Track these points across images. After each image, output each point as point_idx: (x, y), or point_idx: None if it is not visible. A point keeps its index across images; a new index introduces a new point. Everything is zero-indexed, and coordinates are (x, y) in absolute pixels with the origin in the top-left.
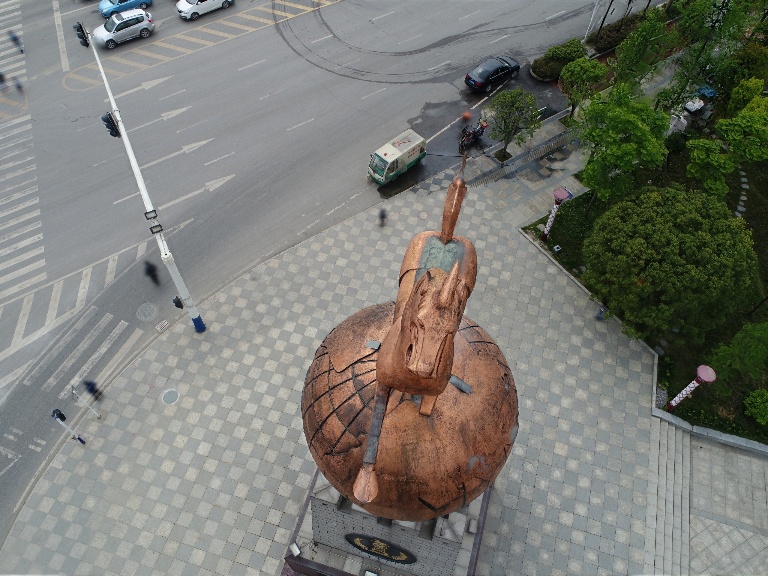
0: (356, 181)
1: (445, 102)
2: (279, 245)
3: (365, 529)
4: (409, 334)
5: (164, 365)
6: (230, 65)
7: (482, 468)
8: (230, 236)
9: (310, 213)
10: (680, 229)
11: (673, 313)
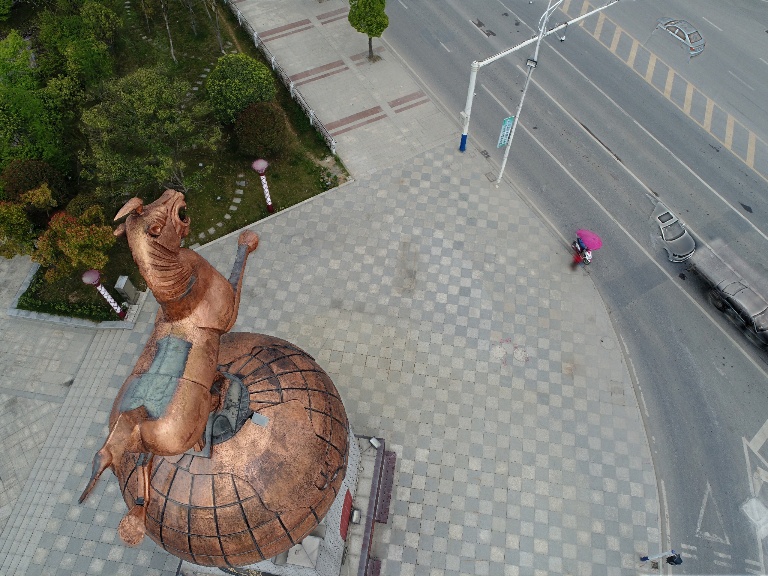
0: None
1: None
2: None
3: None
4: (186, 253)
5: None
6: None
7: None
8: None
9: None
10: None
11: None
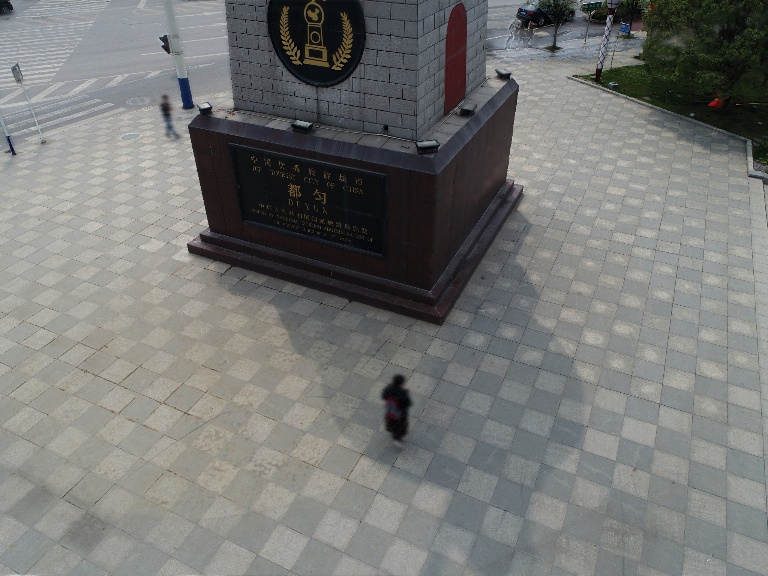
0: None
1: (495, 28)
2: None
3: None
4: None
5: (136, 122)
6: None
7: None
8: None
9: None
10: None
11: (765, 52)
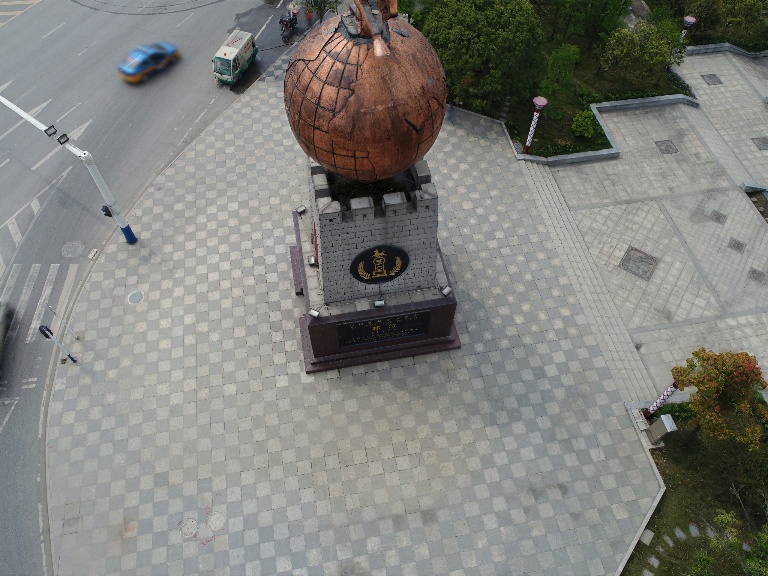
0: (208, 90)
1: (252, 9)
2: (166, 158)
3: (366, 239)
4: None
5: (115, 279)
6: (31, 36)
7: (436, 89)
8: (116, 167)
9: (180, 126)
10: (481, 10)
11: (501, 77)
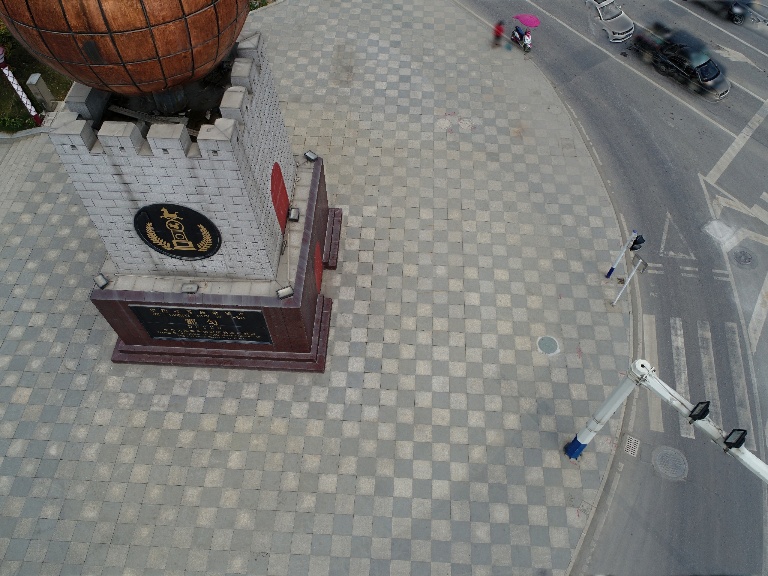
0: None
1: None
2: None
3: None
4: None
5: (585, 383)
6: None
7: None
8: None
9: None
10: None
11: None
